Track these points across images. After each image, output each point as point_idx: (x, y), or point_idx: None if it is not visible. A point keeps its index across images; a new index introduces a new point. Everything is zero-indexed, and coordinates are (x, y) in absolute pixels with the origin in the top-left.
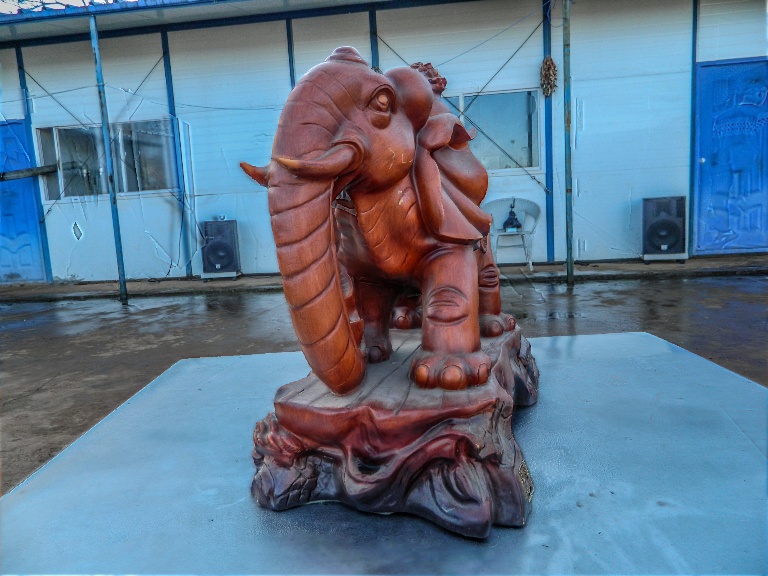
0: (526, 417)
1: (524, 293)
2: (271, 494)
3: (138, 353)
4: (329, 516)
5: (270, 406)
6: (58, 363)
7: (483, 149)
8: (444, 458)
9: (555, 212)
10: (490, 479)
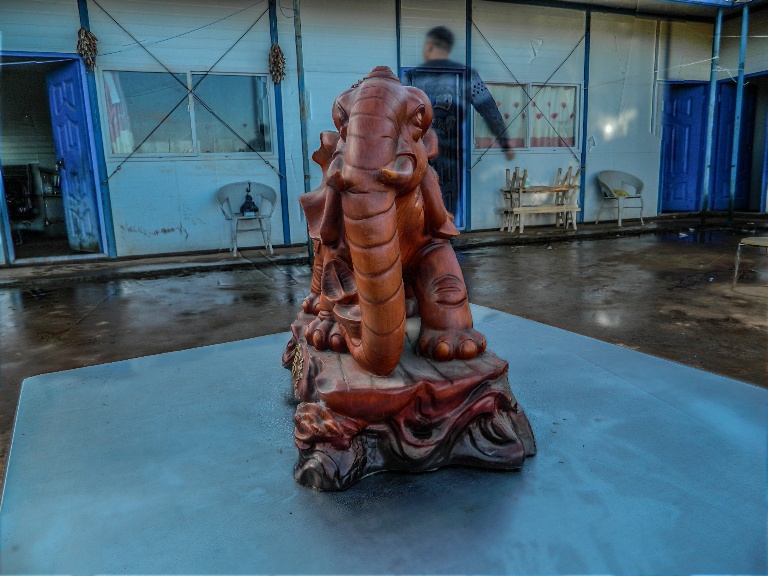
0: None
1: (274, 276)
2: (336, 477)
3: None
4: (390, 483)
5: (217, 407)
6: None
7: (215, 131)
8: (486, 413)
9: (289, 196)
10: (512, 423)
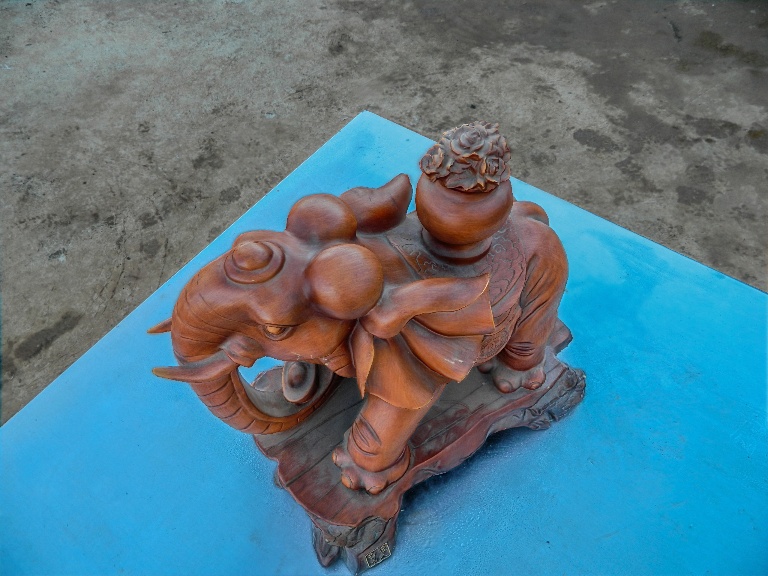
0: (511, 445)
1: None
2: None
3: None
4: (274, 465)
5: None
6: None
7: None
8: None
9: None
10: None
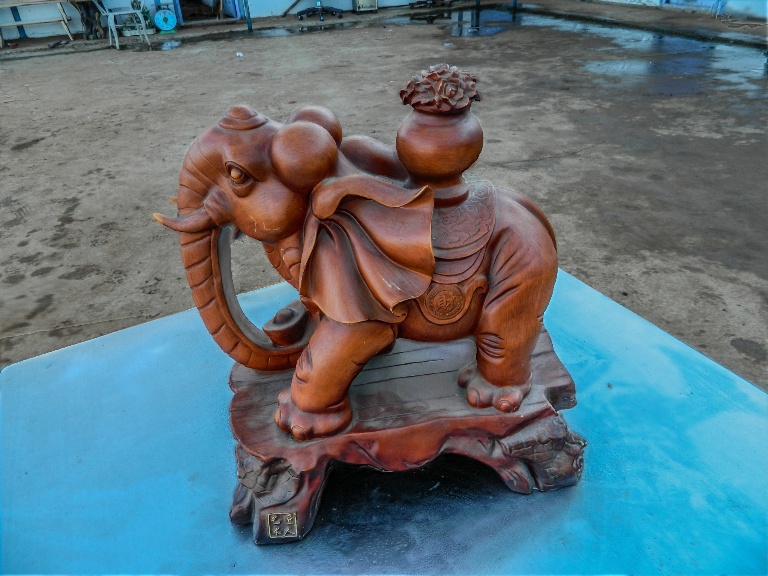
0: (478, 495)
1: None
2: None
3: (692, 141)
4: None
5: None
6: (617, 128)
7: None
8: None
9: None
10: None
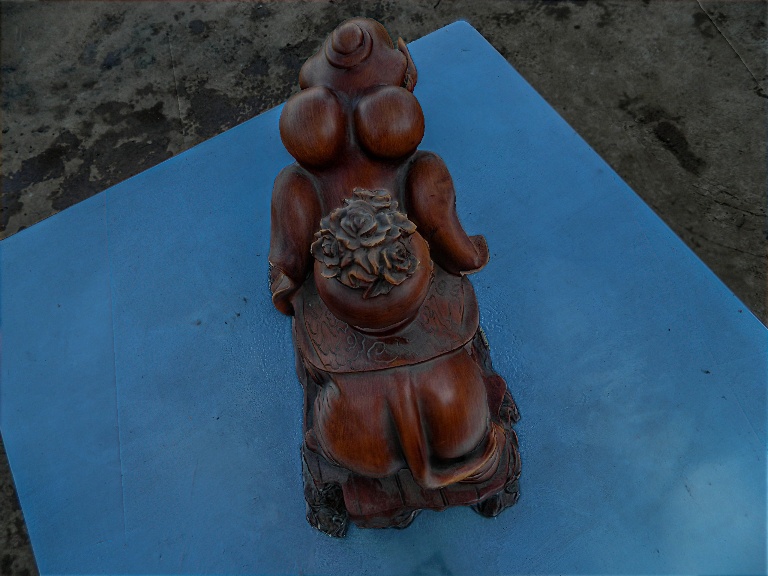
0: None
1: None
2: None
3: None
4: None
5: (568, 353)
6: None
7: None
8: None
9: None
10: None
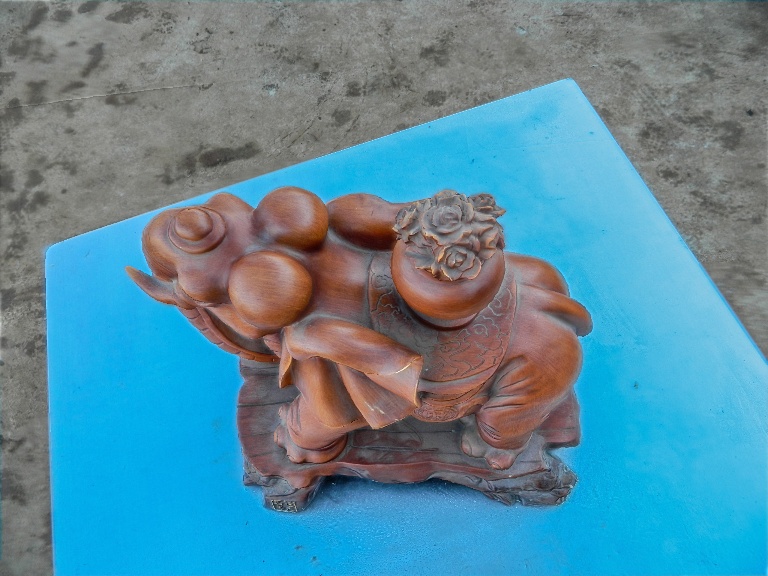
0: (464, 497)
1: None
2: None
3: None
4: None
5: None
6: None
7: None
8: None
9: None
10: None
